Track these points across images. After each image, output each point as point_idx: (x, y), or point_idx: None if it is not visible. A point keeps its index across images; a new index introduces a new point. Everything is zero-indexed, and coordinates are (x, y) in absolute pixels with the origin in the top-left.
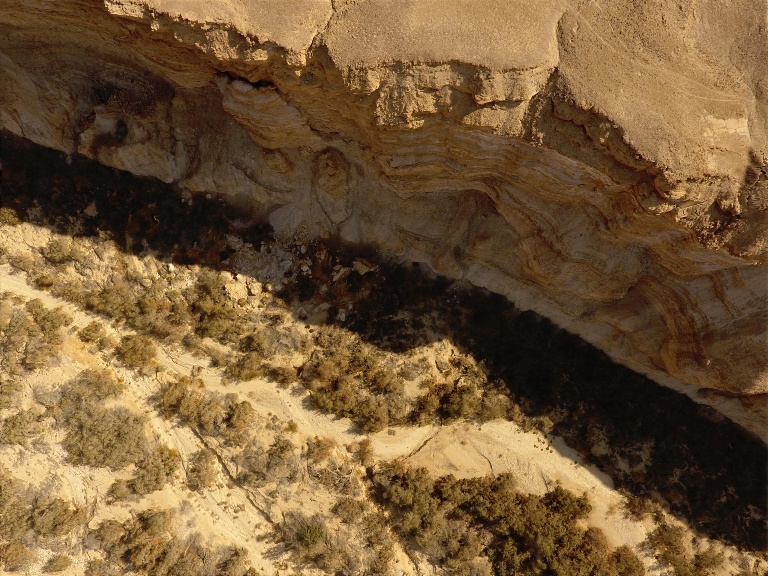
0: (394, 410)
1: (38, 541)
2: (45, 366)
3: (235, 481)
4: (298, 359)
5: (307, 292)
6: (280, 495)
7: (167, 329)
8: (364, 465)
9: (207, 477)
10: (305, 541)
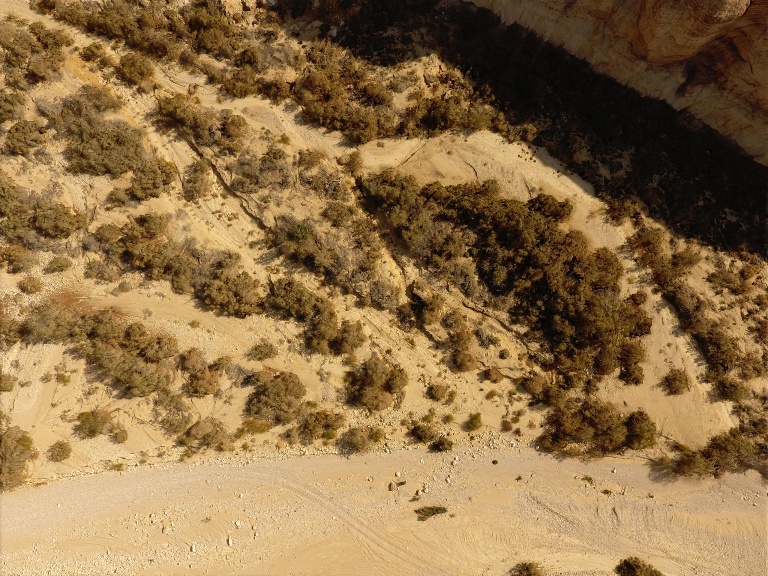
0: (383, 119)
1: (40, 241)
2: (47, 81)
3: (229, 190)
4: (291, 73)
5: (300, 5)
6: (272, 200)
7: (165, 42)
8: (354, 175)
9: (202, 187)
10: (296, 237)
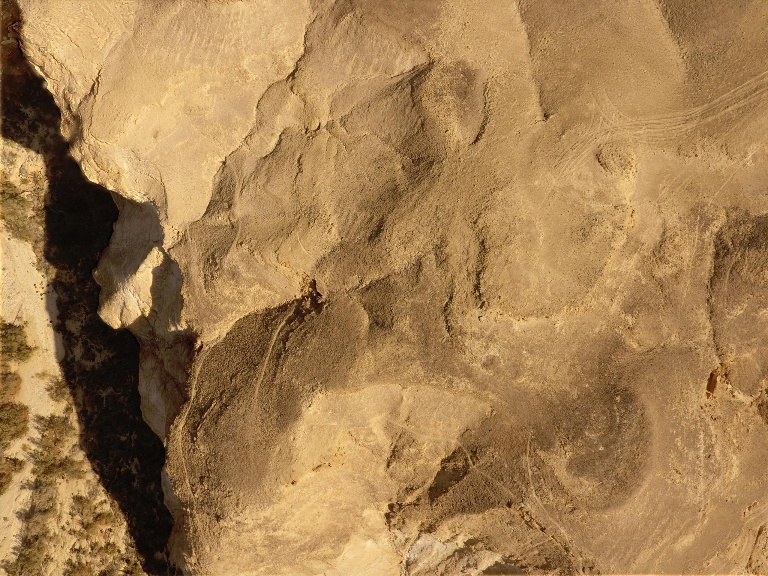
0: None
1: None
2: None
3: None
4: None
5: None
6: None
7: None
8: None
9: None
10: None
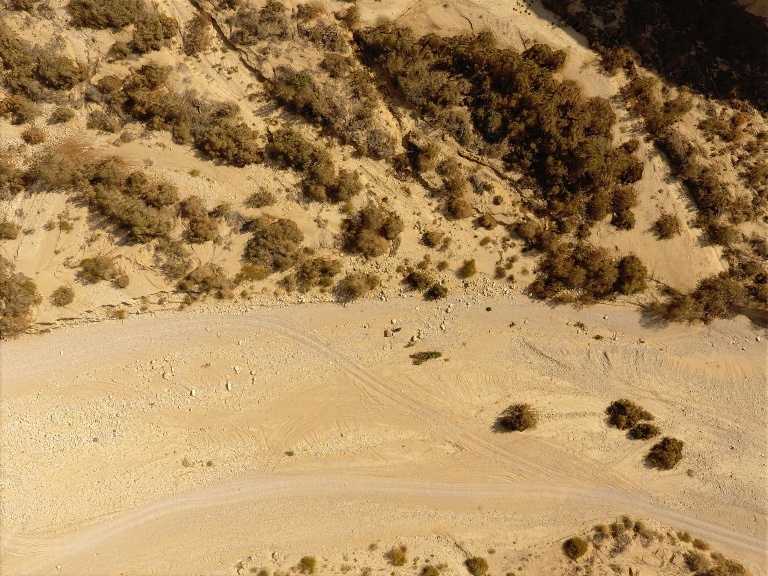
0: None
1: (43, 92)
2: None
3: (229, 44)
4: None
5: None
6: (271, 52)
7: None
8: (351, 29)
9: (202, 41)
10: (294, 84)
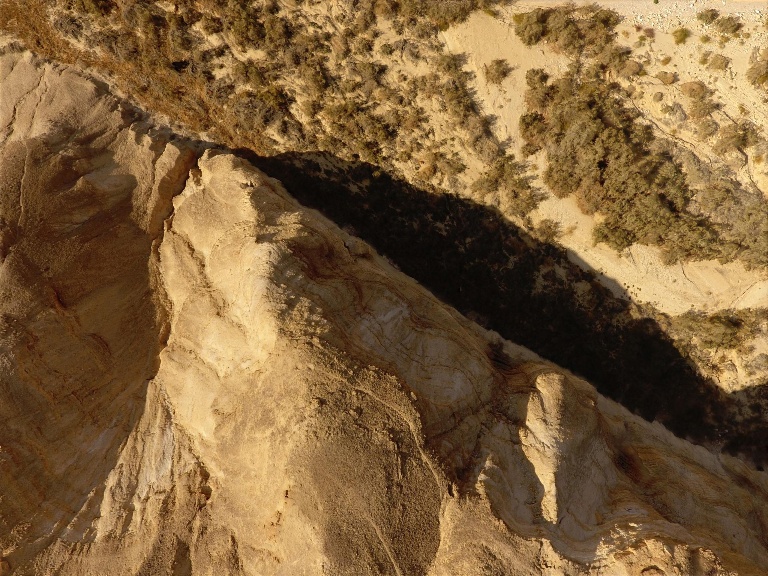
0: None
1: None
2: None
3: None
4: None
5: None
6: None
7: None
8: None
9: None
10: None
